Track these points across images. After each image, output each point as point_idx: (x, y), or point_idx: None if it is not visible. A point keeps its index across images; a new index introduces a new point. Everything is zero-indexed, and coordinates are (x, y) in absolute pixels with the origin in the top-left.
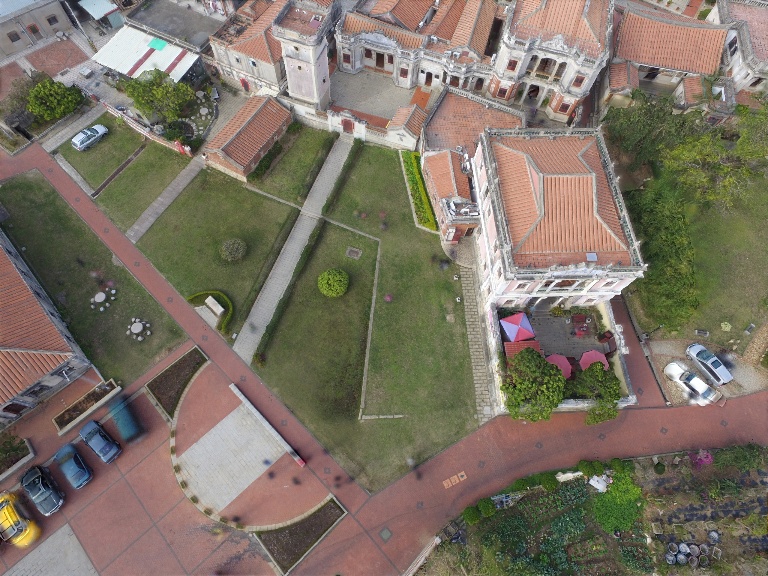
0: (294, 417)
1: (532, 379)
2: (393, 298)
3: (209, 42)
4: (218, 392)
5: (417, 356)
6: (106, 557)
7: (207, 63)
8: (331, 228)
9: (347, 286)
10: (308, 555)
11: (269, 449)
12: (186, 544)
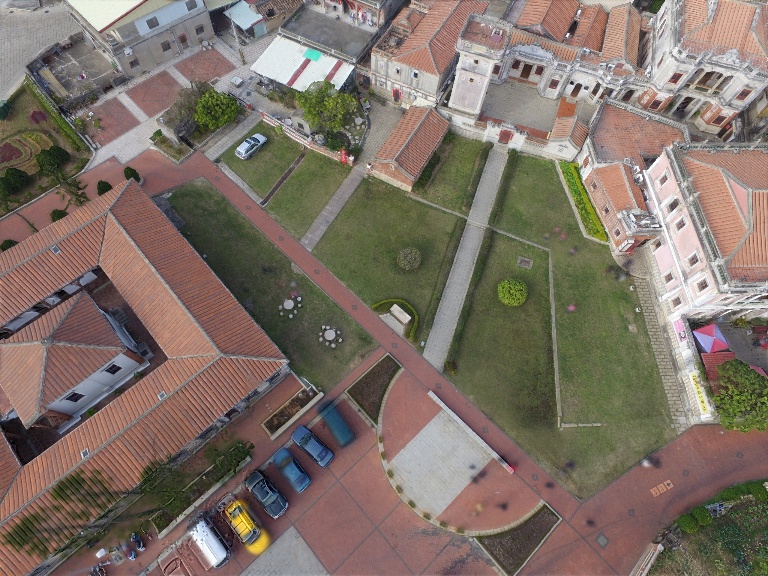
0: (494, 424)
1: (751, 391)
2: (573, 308)
3: (371, 53)
4: (417, 399)
5: (606, 365)
6: (335, 559)
7: (360, 73)
8: (499, 238)
9: (527, 295)
10: (530, 560)
11: (475, 456)
12: (410, 548)
